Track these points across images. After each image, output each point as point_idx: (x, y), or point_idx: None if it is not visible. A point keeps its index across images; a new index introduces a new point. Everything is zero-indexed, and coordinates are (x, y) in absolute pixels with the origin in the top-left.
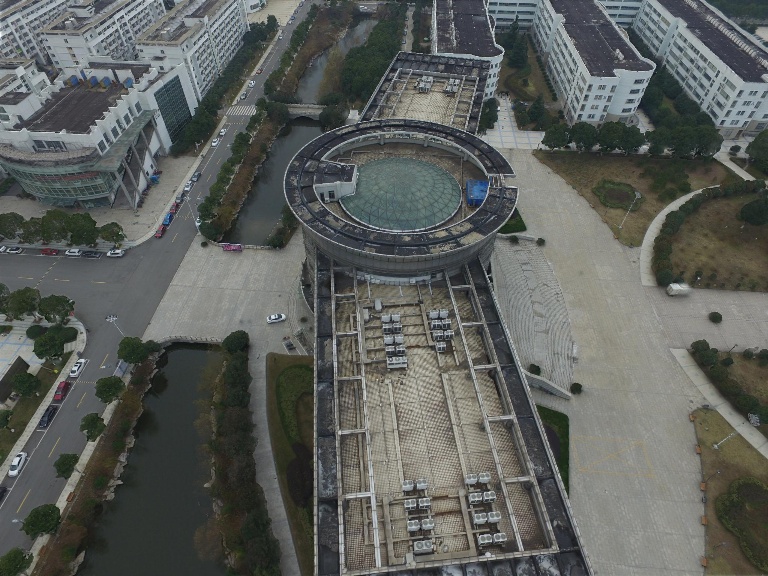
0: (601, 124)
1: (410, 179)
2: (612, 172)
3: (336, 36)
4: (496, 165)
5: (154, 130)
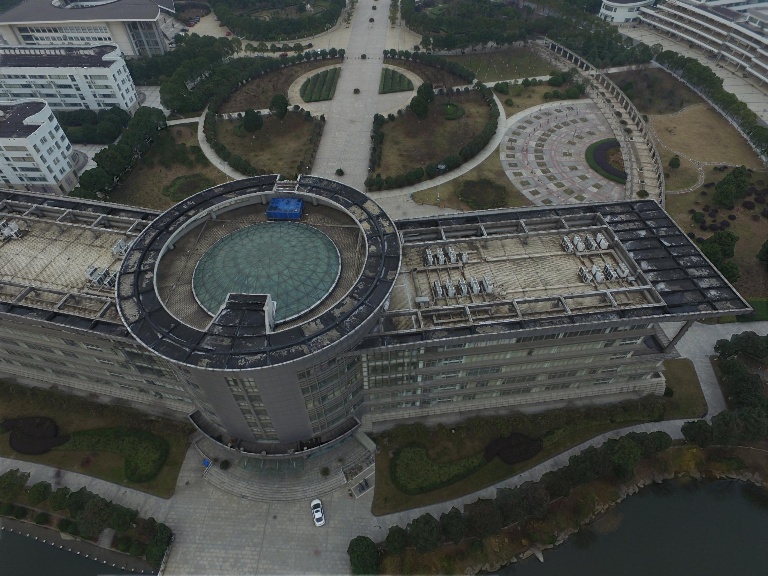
0: (74, 170)
1: (268, 247)
2: (153, 184)
3: None
4: (260, 184)
5: None
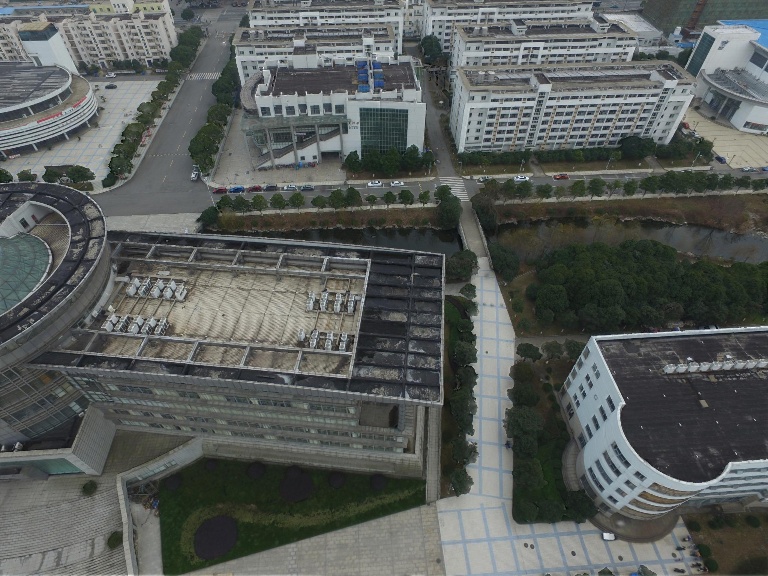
0: None
1: None
2: None
3: (744, 225)
4: None
5: (340, 134)
